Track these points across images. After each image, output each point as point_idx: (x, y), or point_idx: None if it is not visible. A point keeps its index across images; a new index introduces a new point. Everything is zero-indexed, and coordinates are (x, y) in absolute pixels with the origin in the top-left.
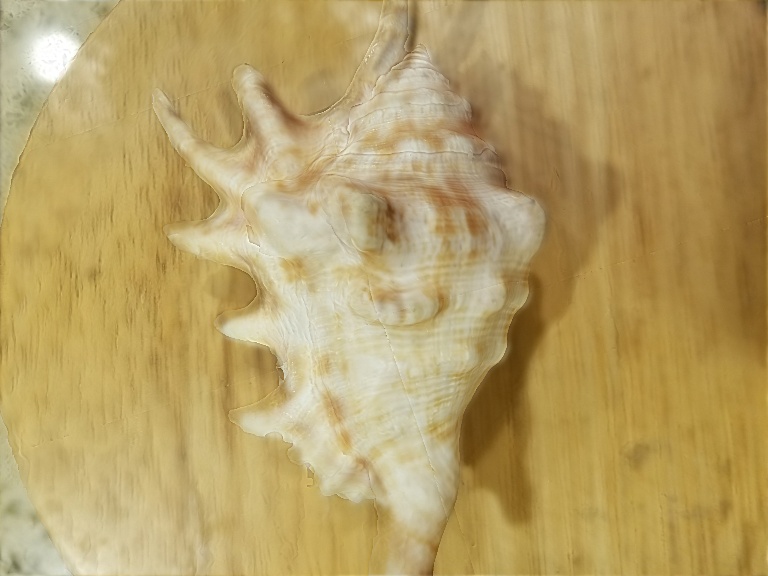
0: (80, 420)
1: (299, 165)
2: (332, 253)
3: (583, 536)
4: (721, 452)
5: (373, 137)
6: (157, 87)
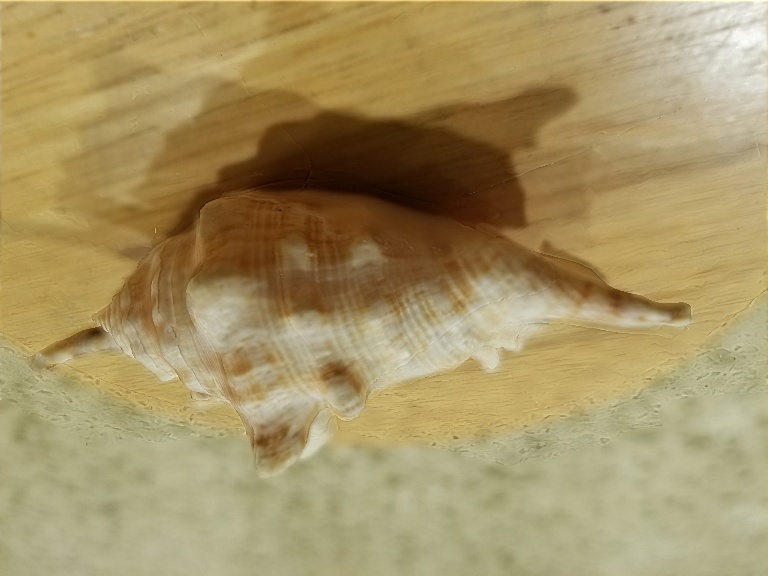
0: (513, 389)
1: None
2: (318, 415)
3: (586, 14)
4: None
5: None
6: None
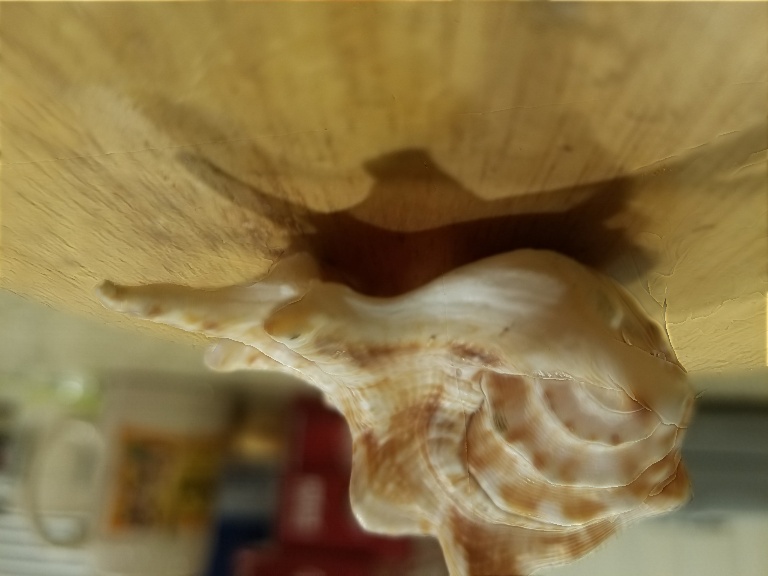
0: None
1: (405, 407)
2: None
3: None
4: (754, 350)
5: (527, 498)
6: (21, 138)
